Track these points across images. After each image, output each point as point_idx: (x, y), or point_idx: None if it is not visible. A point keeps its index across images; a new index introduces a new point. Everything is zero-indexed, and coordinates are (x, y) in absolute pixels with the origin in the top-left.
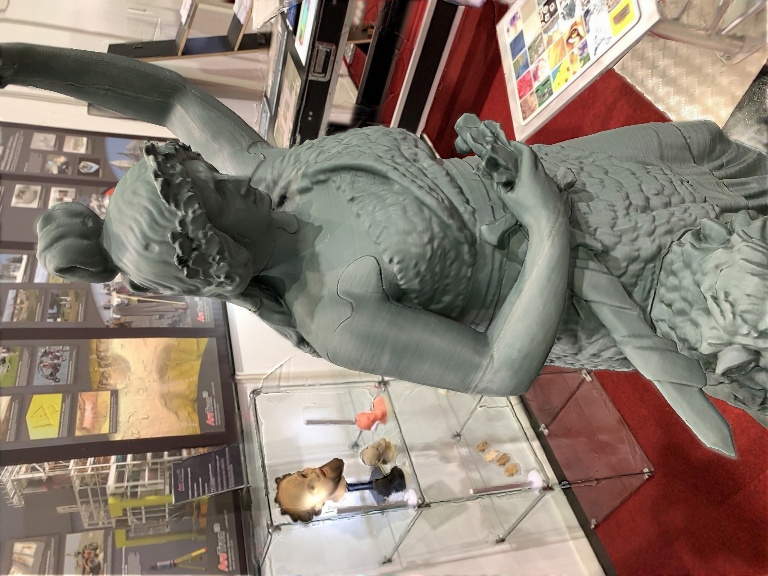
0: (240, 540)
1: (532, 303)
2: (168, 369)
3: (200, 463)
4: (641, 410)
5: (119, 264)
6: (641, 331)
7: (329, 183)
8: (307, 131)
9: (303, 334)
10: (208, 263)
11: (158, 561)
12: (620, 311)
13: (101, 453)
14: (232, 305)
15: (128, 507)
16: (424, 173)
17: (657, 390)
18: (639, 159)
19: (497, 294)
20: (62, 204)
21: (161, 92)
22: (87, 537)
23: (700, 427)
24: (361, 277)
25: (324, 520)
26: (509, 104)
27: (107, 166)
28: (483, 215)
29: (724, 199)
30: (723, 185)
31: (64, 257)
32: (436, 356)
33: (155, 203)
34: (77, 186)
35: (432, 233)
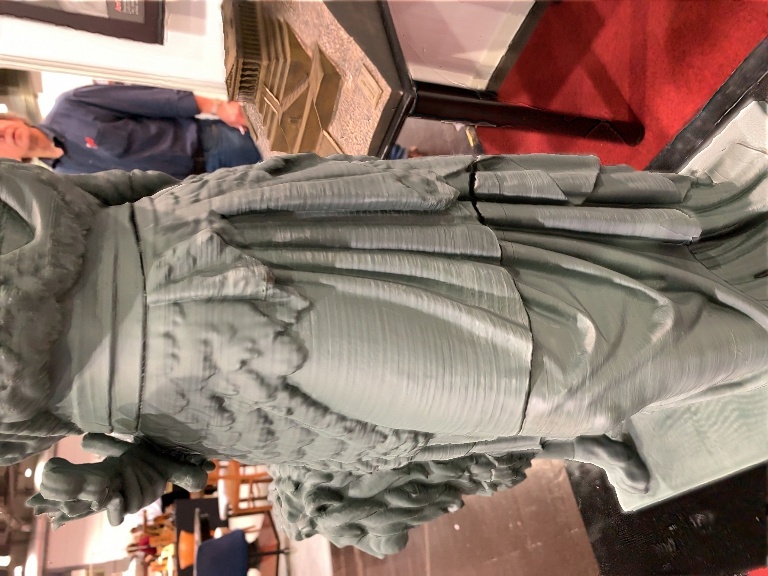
0: None
1: None
2: None
3: None
4: None
5: None
6: None
7: None
8: None
9: None
10: None
11: None
12: None
13: None
14: None
15: None
16: (6, 436)
17: None
18: None
19: None
20: None
21: None
22: None
23: None
24: None
25: None
26: None
27: None
28: None
29: (459, 442)
30: None
31: None
32: None
33: None
34: None
35: None
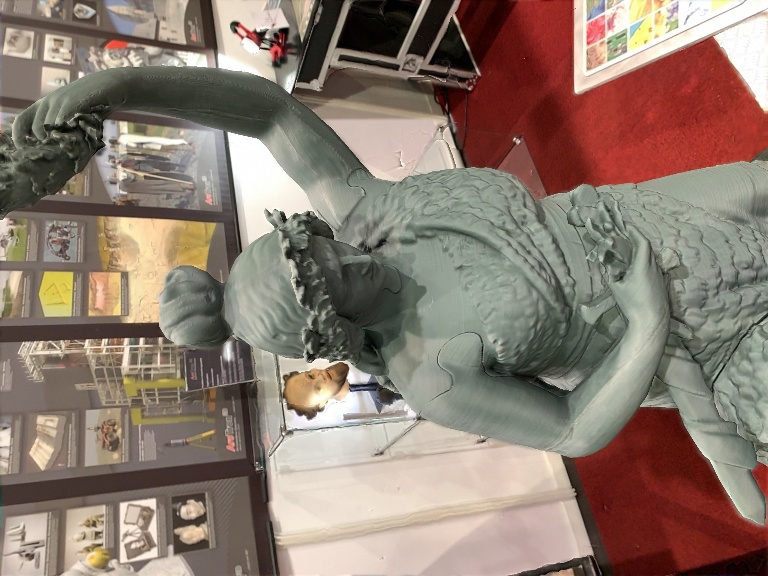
0: (246, 425)
1: (620, 392)
2: (177, 253)
3: (212, 354)
4: None
5: (239, 337)
6: (710, 416)
7: (435, 240)
8: (330, 2)
9: (394, 384)
10: (330, 350)
11: (171, 439)
12: (695, 397)
13: (114, 335)
14: (240, 188)
15: (142, 388)
16: (532, 241)
17: None
18: (731, 214)
19: (579, 357)
20: (183, 272)
21: (262, 112)
22: (105, 414)
23: (741, 502)
24: (463, 351)
25: (333, 427)
26: (573, 46)
27: (105, 12)
28: (582, 288)
29: None
30: None
31: (192, 337)
32: (522, 426)
33: (289, 301)
34: (73, 35)
35: (537, 316)
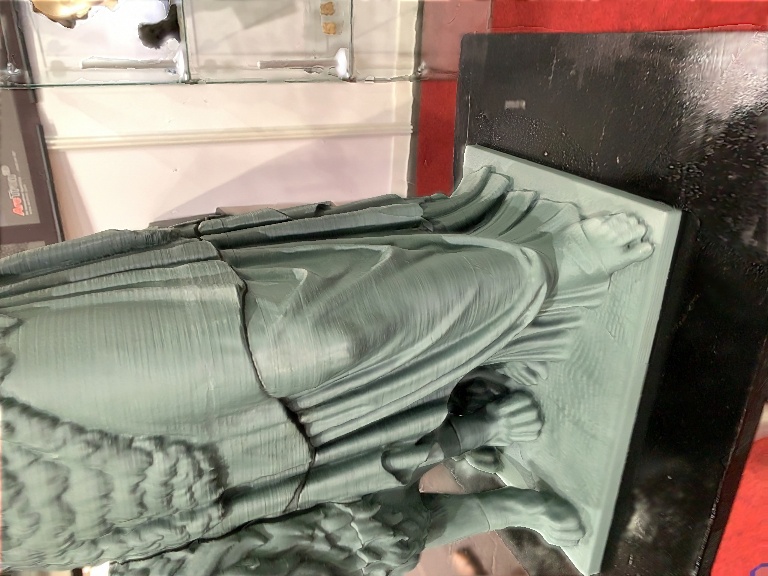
0: None
1: None
2: None
3: None
4: (508, 14)
5: None
6: None
7: None
8: None
9: None
10: None
11: None
12: None
13: None
14: None
15: None
16: None
17: (533, 9)
18: (156, 434)
19: None
20: None
21: None
22: None
23: None
24: None
25: None
26: None
27: None
28: None
29: (268, 471)
30: (297, 434)
31: None
32: None
33: None
34: None
35: None
